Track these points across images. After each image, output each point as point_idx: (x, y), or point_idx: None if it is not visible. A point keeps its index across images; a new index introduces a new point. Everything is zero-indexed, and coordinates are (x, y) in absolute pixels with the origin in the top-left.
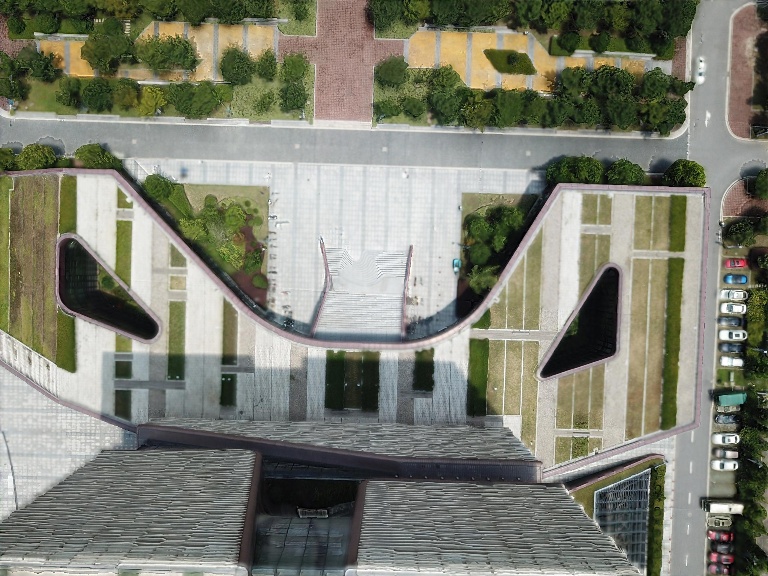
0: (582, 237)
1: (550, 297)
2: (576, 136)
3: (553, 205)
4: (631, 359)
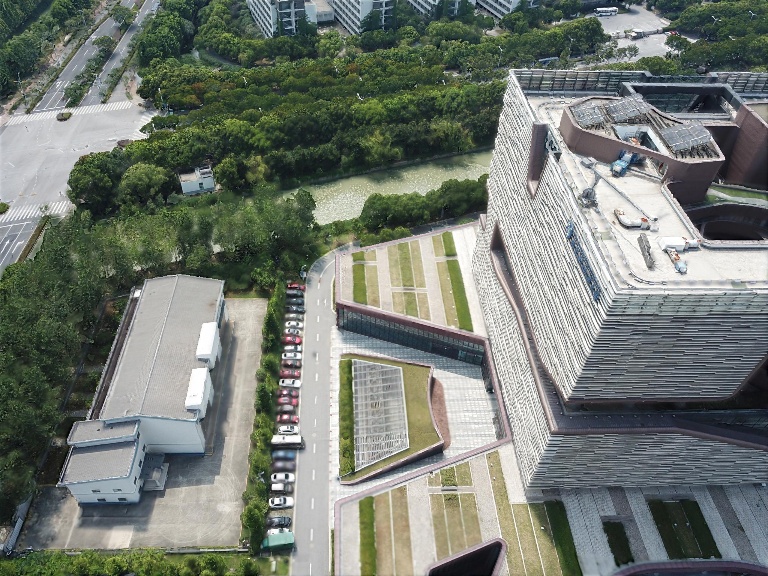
0: None
1: None
2: None
3: None
4: (411, 567)
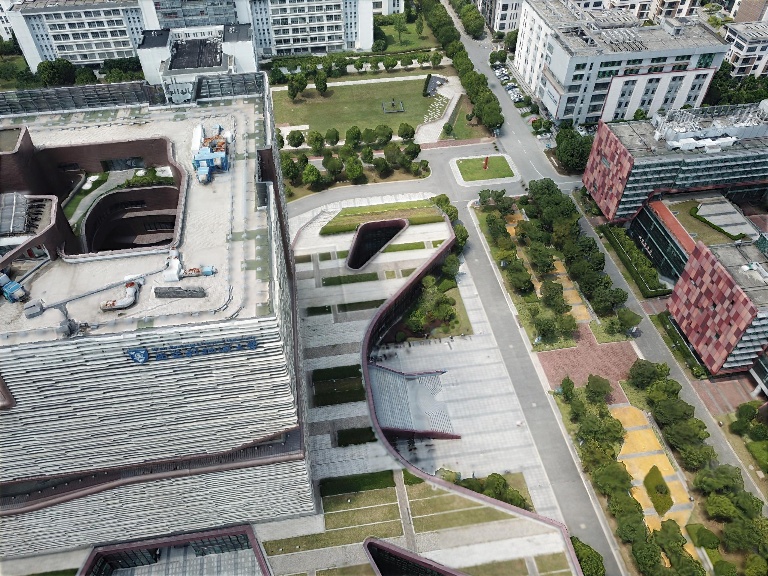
0: (521, 560)
1: (451, 539)
2: (622, 573)
3: (542, 524)
4: None
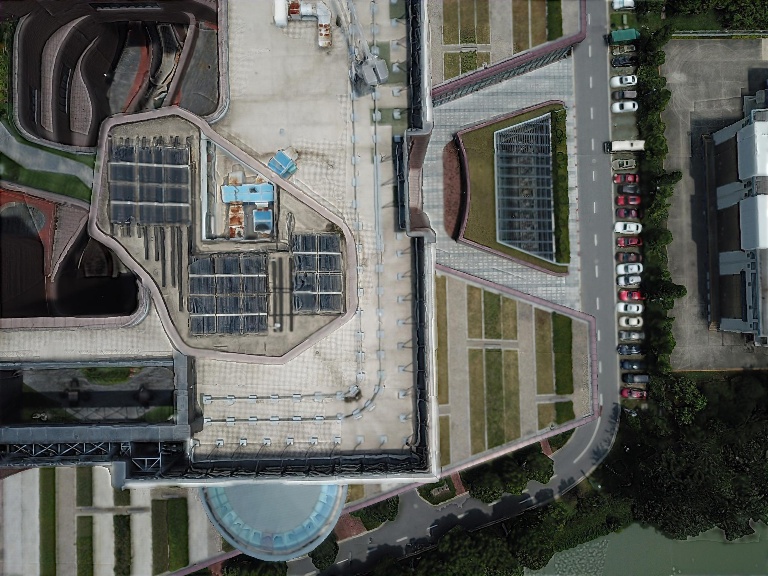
0: None
1: None
2: None
3: None
4: None
